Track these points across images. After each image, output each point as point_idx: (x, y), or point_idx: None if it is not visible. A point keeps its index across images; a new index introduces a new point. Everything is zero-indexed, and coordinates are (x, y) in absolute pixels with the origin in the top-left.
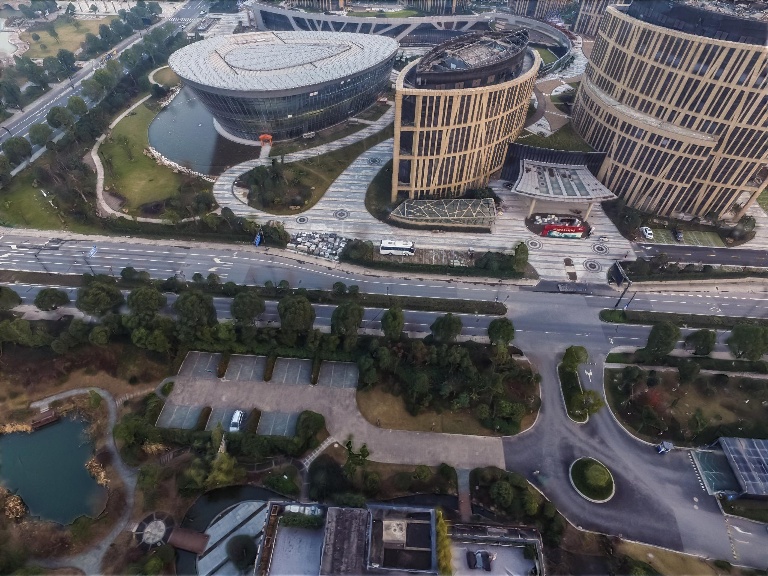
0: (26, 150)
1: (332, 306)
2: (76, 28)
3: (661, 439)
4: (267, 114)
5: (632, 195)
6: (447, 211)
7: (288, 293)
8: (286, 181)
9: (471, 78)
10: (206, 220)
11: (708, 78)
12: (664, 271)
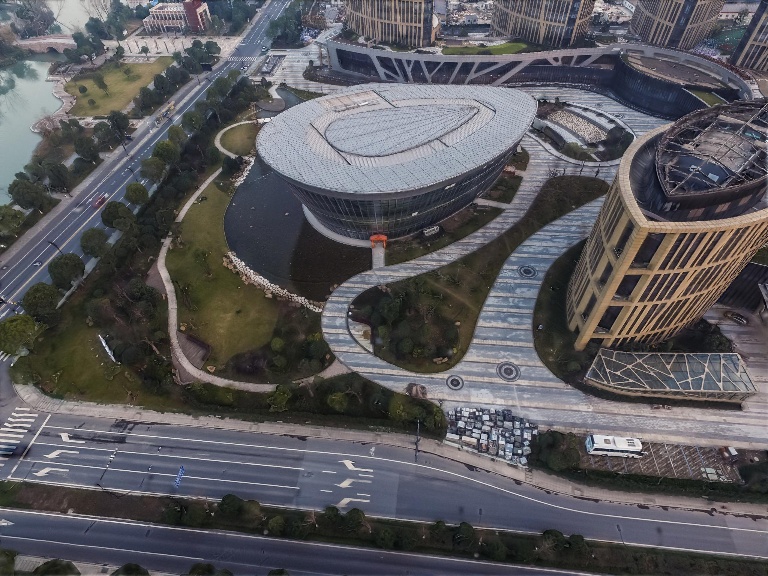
0: (78, 271)
1: (544, 570)
2: (126, 75)
3: None
4: (387, 215)
5: None
6: (674, 376)
7: (471, 543)
8: (425, 319)
9: (741, 195)
10: (333, 405)
11: None
12: None
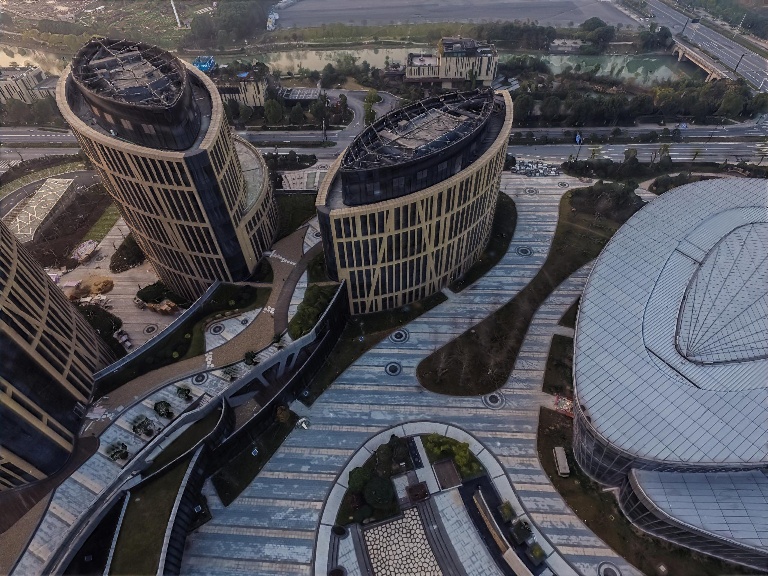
0: None
1: None
2: None
3: None
4: None
5: None
6: None
7: None
8: None
9: None
10: None
11: None
12: (276, 159)
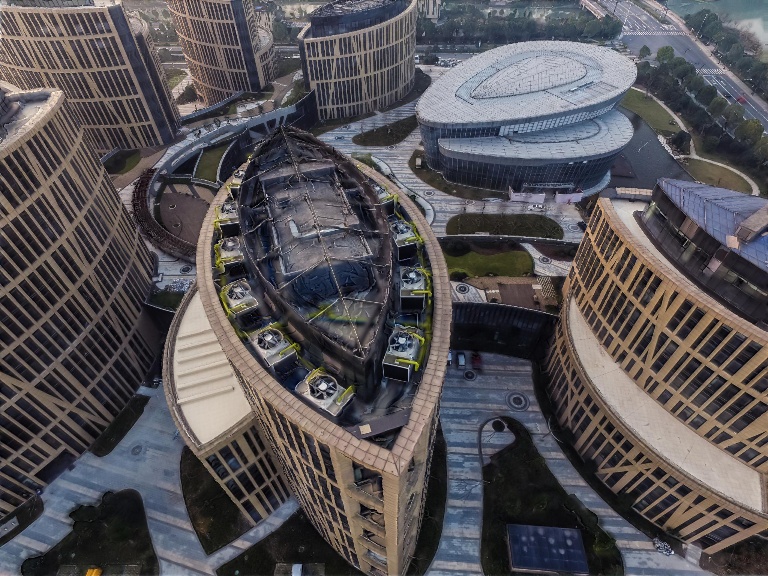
0: None
1: None
2: None
3: None
4: None
5: None
6: None
7: None
8: None
9: None
10: None
11: None
12: None
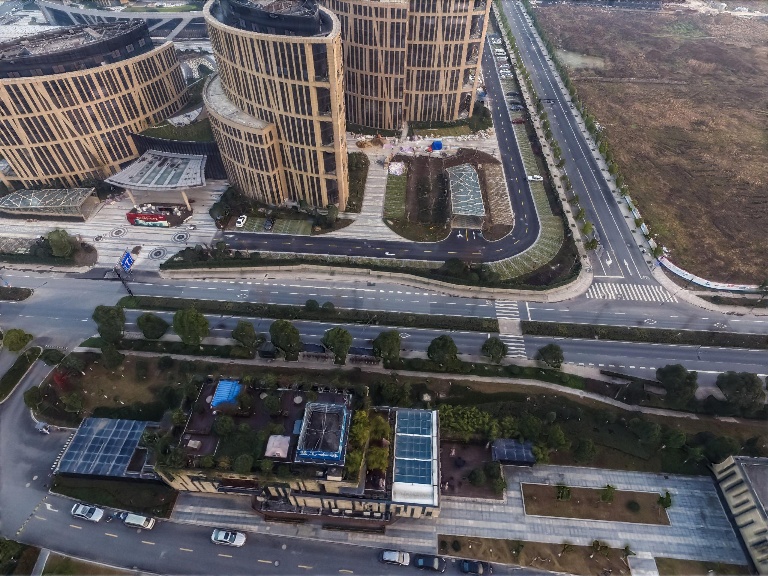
0: None
1: None
2: None
3: (56, 420)
4: None
5: (242, 184)
6: (41, 200)
7: None
8: None
9: (26, 68)
10: None
11: (239, 66)
12: None
